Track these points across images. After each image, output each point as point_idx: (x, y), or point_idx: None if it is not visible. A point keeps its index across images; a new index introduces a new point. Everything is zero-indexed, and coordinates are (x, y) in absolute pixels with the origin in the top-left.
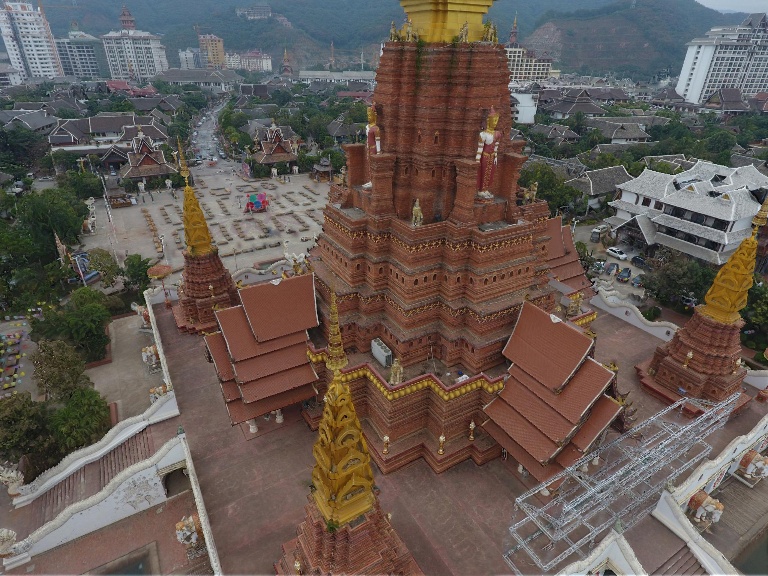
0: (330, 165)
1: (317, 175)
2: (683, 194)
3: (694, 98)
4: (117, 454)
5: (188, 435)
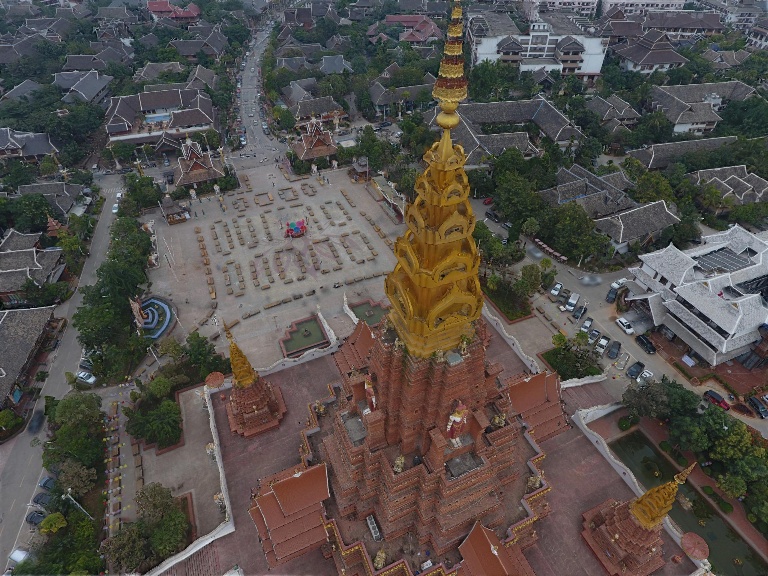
0: (368, 167)
1: (355, 175)
2: (697, 288)
3: None
4: (196, 559)
5: (241, 553)
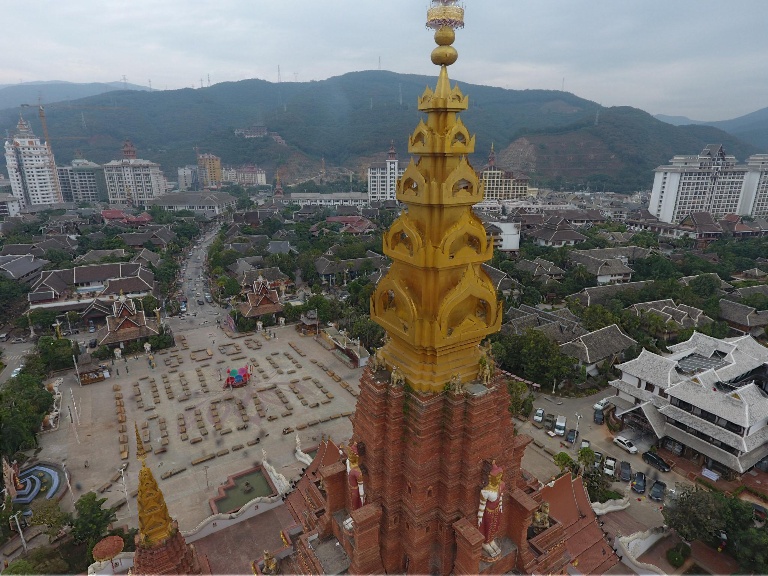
0: (317, 319)
1: (304, 329)
2: (689, 386)
3: (667, 218)
4: None
5: None
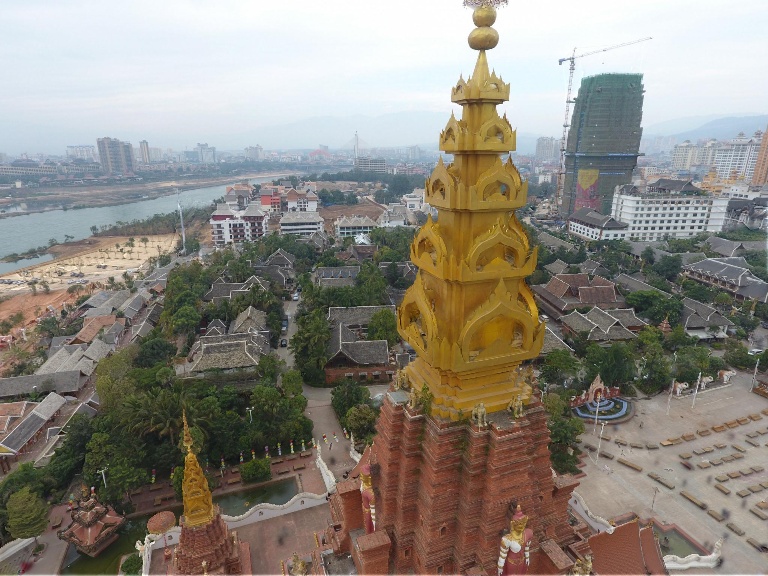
0: None
1: None
2: None
3: None
4: None
5: None
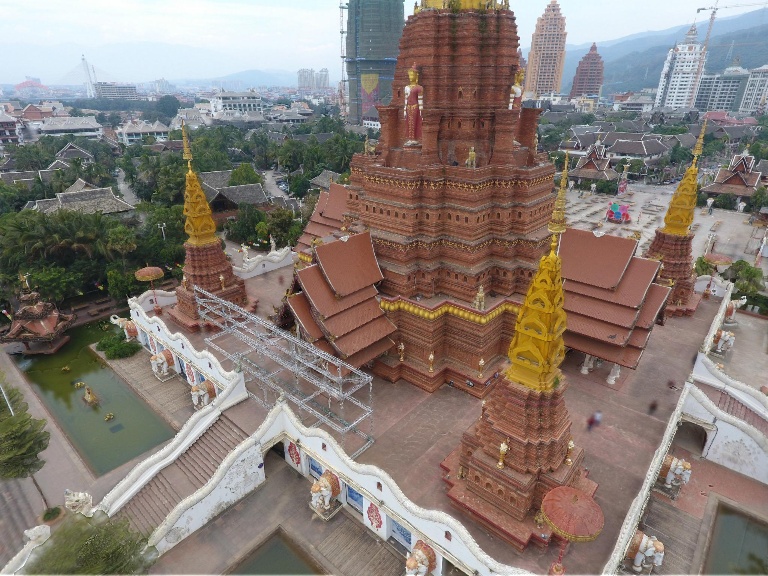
0: None
1: (754, 216)
2: None
3: None
4: None
5: None
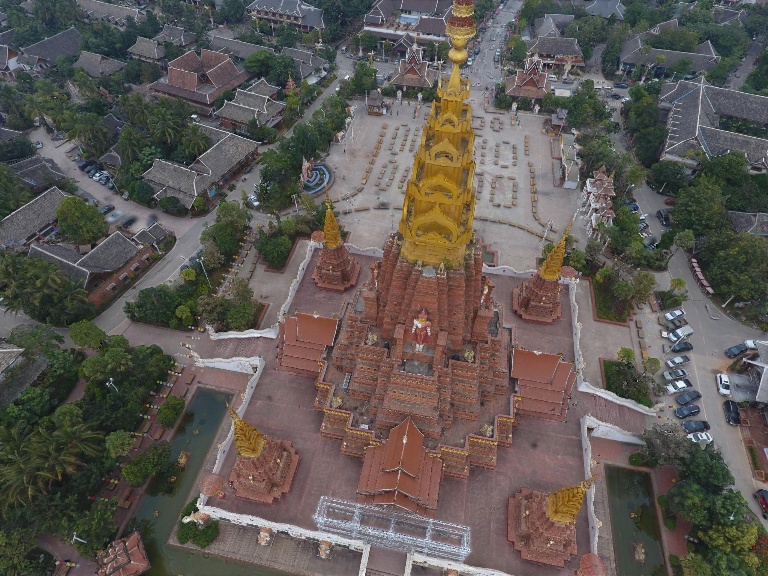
0: (564, 121)
1: (548, 126)
2: None
3: None
4: (246, 342)
5: (271, 353)
